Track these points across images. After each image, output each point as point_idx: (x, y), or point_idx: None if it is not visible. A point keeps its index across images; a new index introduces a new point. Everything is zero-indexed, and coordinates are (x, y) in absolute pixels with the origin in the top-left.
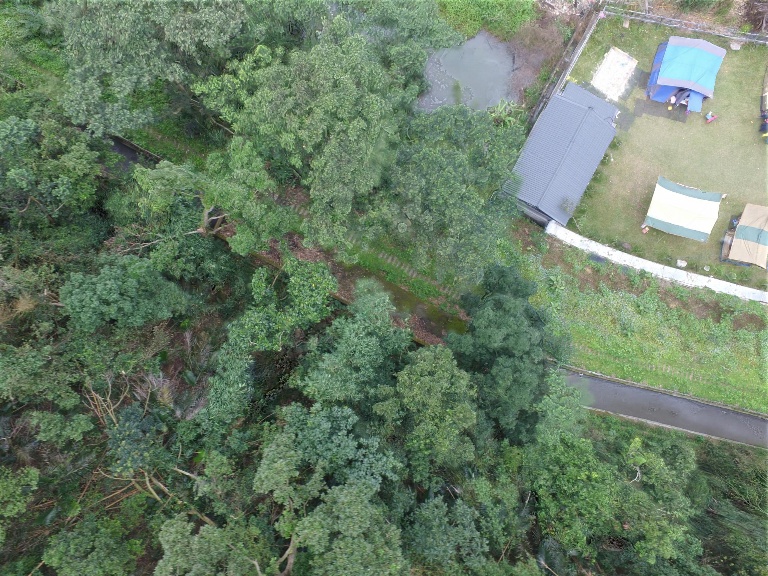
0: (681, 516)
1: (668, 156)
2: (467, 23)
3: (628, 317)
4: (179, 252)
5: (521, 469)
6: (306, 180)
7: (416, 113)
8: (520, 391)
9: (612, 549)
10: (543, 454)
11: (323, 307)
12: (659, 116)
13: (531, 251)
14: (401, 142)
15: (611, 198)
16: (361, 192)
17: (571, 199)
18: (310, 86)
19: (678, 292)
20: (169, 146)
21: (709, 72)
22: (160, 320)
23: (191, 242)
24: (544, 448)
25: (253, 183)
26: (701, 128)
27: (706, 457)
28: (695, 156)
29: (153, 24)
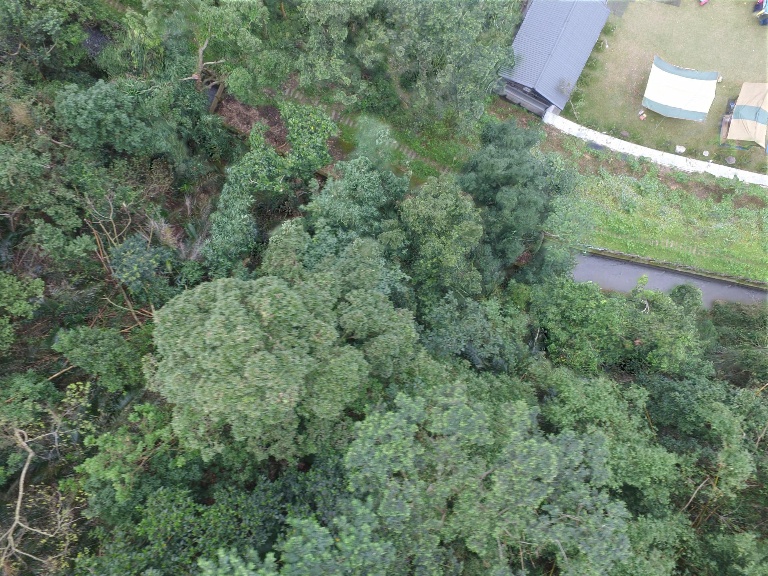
0: (691, 345)
1: (663, 41)
2: None
3: (629, 197)
4: (174, 101)
5: (529, 309)
6: (301, 6)
7: None
8: (525, 210)
9: (624, 377)
10: (550, 291)
11: (323, 153)
12: (652, 1)
13: None
14: None
15: (607, 85)
16: (357, 13)
17: (567, 82)
18: None
19: (678, 176)
20: (160, 31)
21: None
22: (158, 152)
23: (186, 91)
24: (551, 286)
25: (247, 11)
26: (695, 11)
27: (713, 317)
28: (690, 40)
29: None
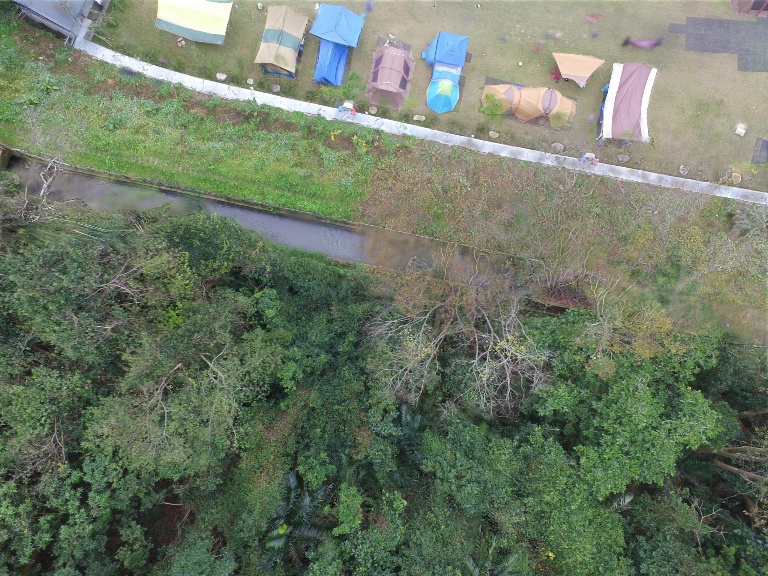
0: None
1: None
2: None
3: (129, 117)
4: None
5: None
6: None
7: None
8: None
9: None
10: None
11: None
12: None
13: (41, 60)
14: None
15: (143, 12)
16: None
17: (72, 1)
18: None
19: None
20: None
21: None
22: None
23: None
24: None
25: None
26: None
27: None
28: None
29: None
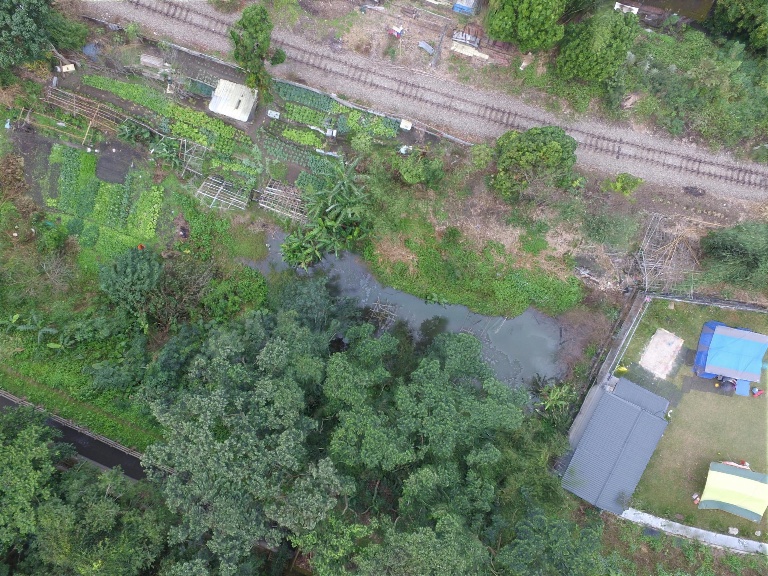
0: None
1: (716, 429)
2: (515, 306)
3: None
4: None
5: None
6: None
7: (495, 521)
8: None
9: None
10: None
11: None
12: (706, 391)
13: None
14: (485, 570)
15: (662, 471)
16: None
17: (626, 491)
18: (407, 572)
19: (732, 564)
20: None
21: (756, 358)
22: None
23: None
24: None
25: None
26: (748, 401)
27: None
28: (743, 427)
29: (251, 497)
